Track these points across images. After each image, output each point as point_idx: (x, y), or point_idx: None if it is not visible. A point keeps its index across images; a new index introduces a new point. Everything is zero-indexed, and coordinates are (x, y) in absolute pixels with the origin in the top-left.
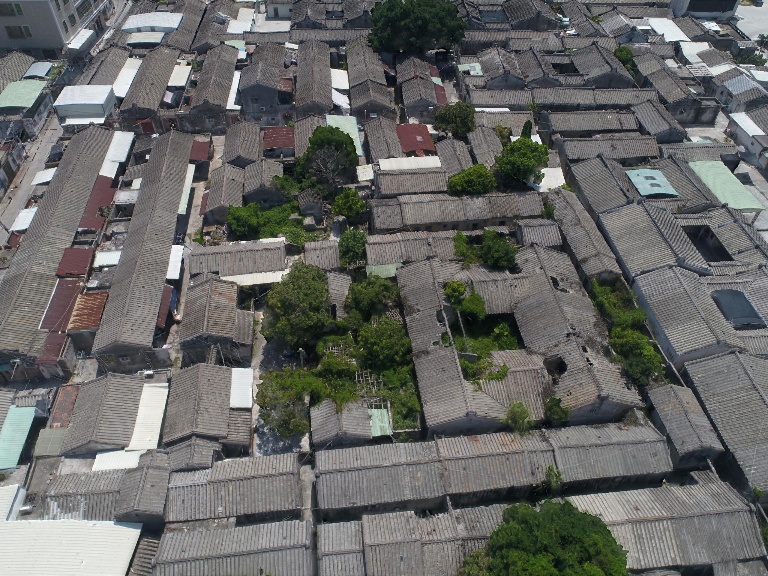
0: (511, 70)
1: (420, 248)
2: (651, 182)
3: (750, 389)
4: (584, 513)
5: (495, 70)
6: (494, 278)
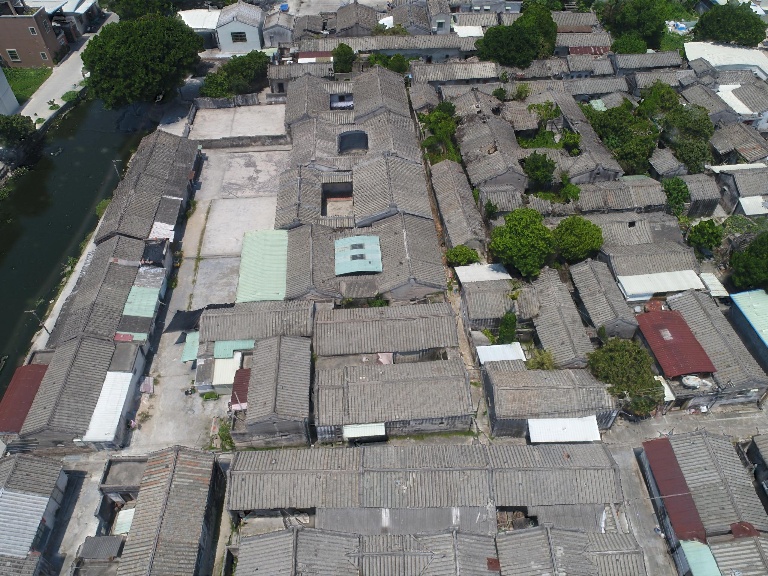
0: (534, 568)
1: (610, 185)
2: (360, 250)
3: (384, 95)
4: (502, 39)
5: (573, 568)
6: (542, 153)
